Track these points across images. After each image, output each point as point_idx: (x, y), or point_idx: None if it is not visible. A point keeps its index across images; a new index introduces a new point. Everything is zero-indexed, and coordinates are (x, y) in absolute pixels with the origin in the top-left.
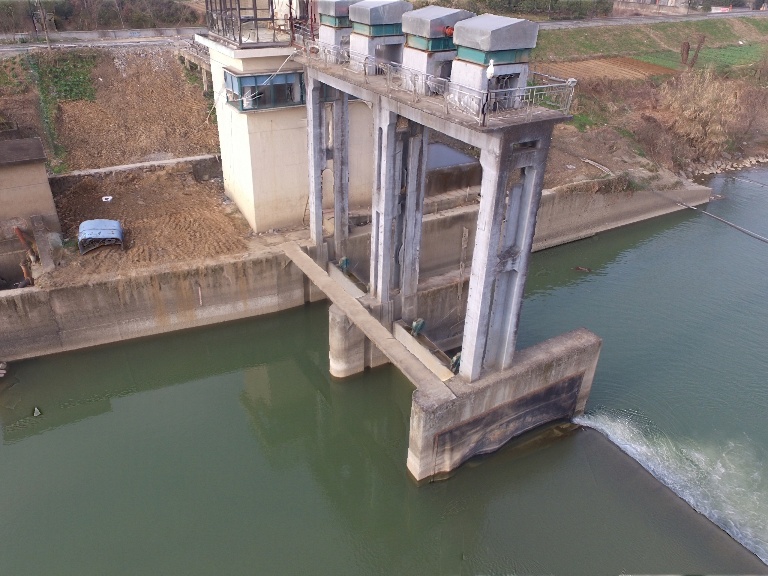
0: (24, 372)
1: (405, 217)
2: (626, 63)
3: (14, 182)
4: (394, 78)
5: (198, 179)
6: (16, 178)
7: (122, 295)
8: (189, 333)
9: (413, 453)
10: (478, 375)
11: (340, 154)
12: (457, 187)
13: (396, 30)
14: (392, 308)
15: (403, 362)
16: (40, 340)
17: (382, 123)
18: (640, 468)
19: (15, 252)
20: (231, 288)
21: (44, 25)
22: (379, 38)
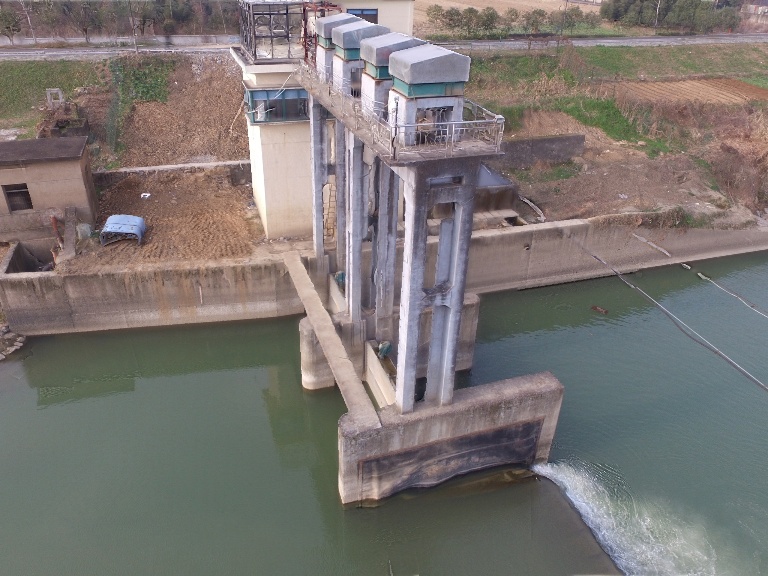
0: (42, 346)
1: (378, 239)
2: (729, 85)
3: (52, 176)
4: None
5: (235, 182)
6: (54, 172)
7: (128, 287)
8: (190, 328)
9: (340, 475)
10: (411, 407)
11: (342, 170)
12: (484, 209)
13: None
14: (364, 327)
15: (345, 384)
16: (55, 320)
17: (350, 145)
18: (584, 530)
19: (51, 238)
20: (231, 290)
21: (133, 31)
22: (355, 61)
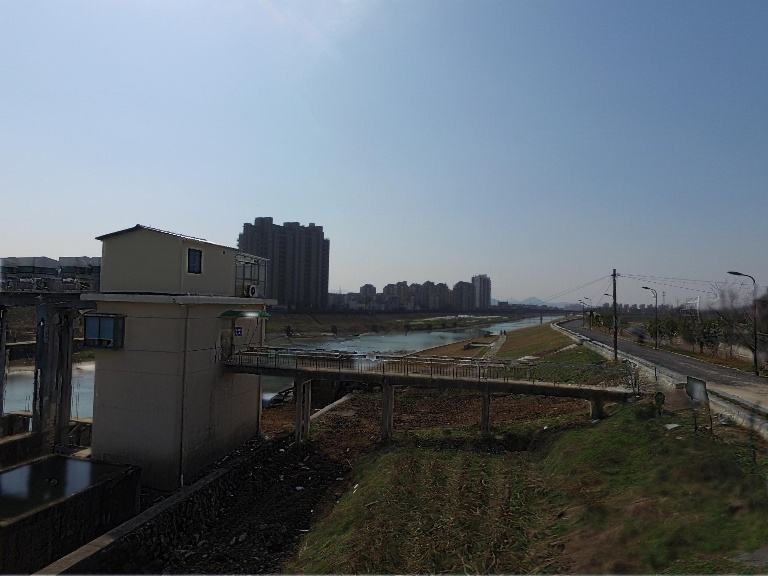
0: None
1: None
2: None
3: None
4: None
5: None
6: None
7: None
8: None
9: None
10: None
11: None
12: None
13: None
14: None
15: None
16: None
17: None
18: None
19: None
20: None
21: None
22: None
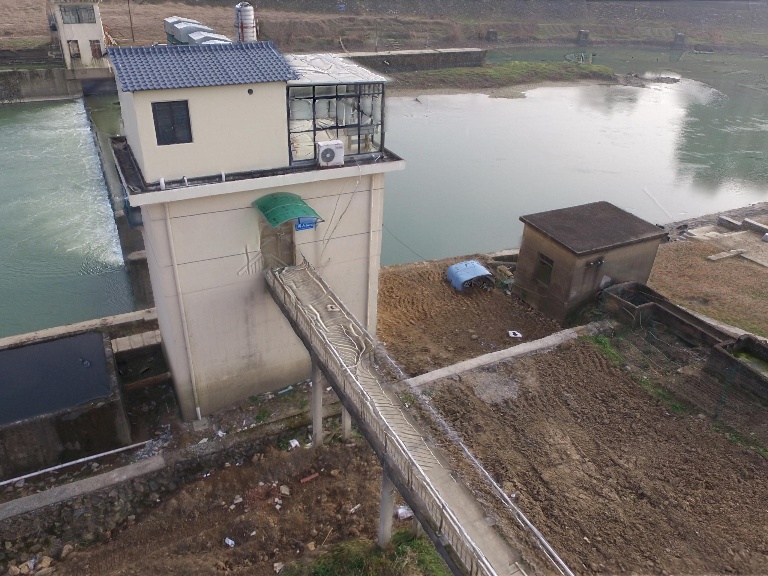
0: None
1: None
2: None
3: None
4: None
5: None
6: None
7: None
8: None
9: None
10: None
11: None
12: None
13: None
14: None
15: None
16: None
17: None
18: None
19: None
20: None
21: None
22: None
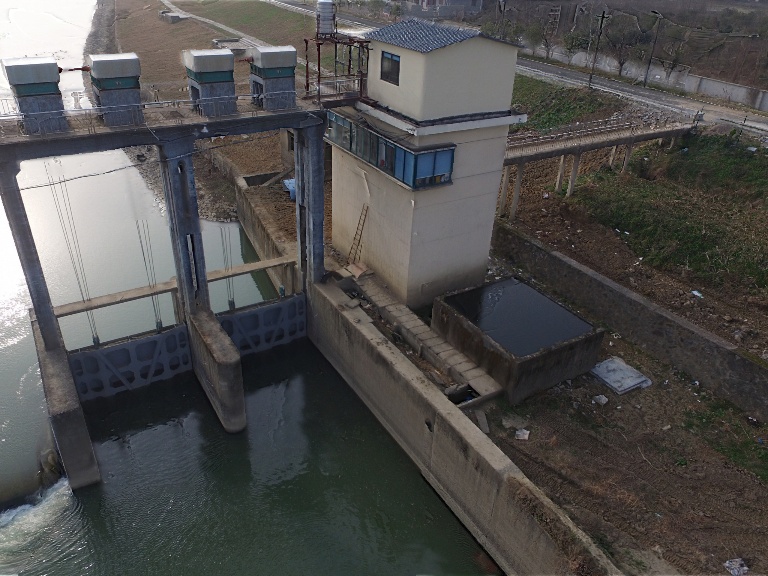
0: None
1: None
2: None
3: None
4: (175, 113)
5: None
6: None
7: None
8: None
9: None
10: None
11: None
12: None
13: None
14: None
15: (87, 301)
16: None
17: None
18: None
19: None
20: None
21: None
22: None
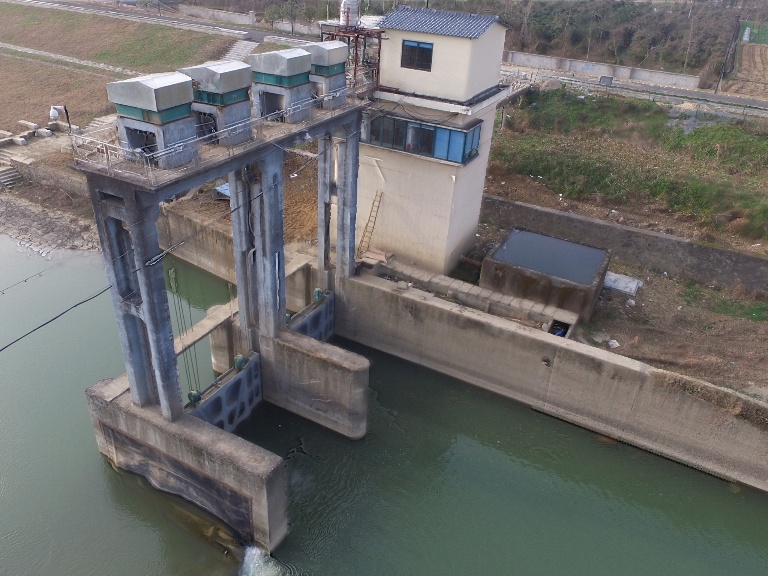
0: None
1: None
2: None
3: None
4: None
5: None
6: None
7: (199, 234)
8: None
9: None
10: None
11: (343, 194)
12: (544, 300)
13: (277, 81)
14: (250, 336)
15: None
16: None
17: None
18: None
19: (206, 184)
20: None
21: None
22: (262, 85)
